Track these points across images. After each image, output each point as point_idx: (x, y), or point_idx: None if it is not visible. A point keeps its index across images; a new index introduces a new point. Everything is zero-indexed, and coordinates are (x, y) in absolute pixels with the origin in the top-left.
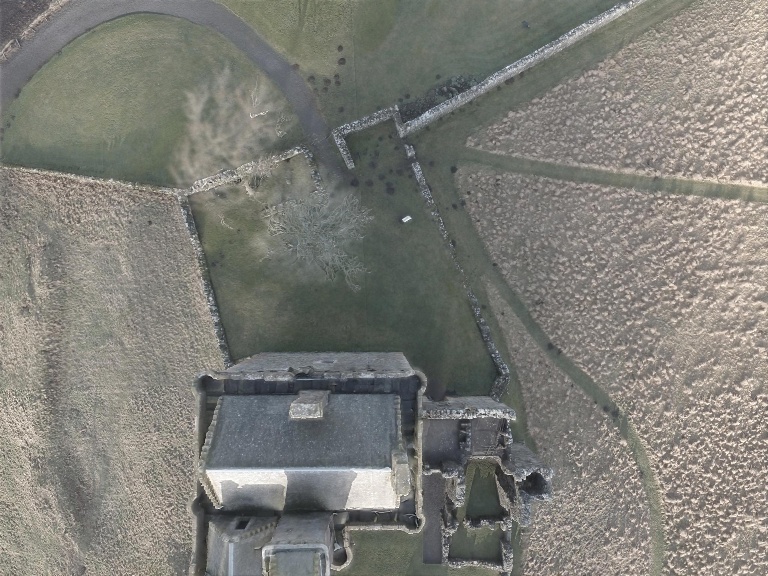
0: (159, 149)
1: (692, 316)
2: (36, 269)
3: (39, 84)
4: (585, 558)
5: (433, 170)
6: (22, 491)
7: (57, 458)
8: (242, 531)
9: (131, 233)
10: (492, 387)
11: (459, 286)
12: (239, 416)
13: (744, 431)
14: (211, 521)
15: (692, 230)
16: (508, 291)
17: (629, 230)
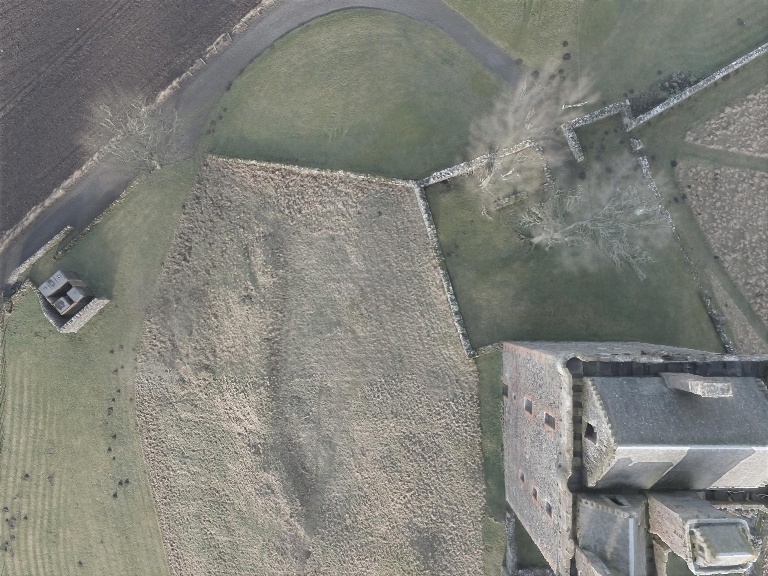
0: (386, 141)
1: None
2: (259, 258)
3: (253, 77)
4: None
5: (655, 164)
6: (235, 477)
7: (279, 444)
8: (630, 507)
9: (361, 223)
10: None
11: (689, 278)
12: (617, 396)
13: None
14: (584, 498)
15: None
16: (729, 283)
17: None
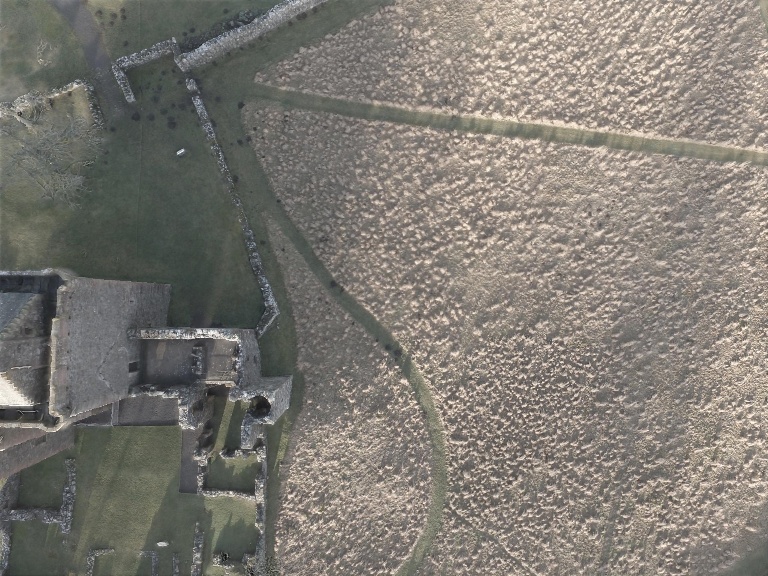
0: None
1: (486, 257)
2: None
3: None
4: (356, 494)
5: (219, 105)
6: None
7: None
8: None
9: None
10: (259, 320)
11: (234, 220)
12: None
13: (538, 374)
14: None
15: (489, 170)
16: (292, 228)
17: (422, 169)
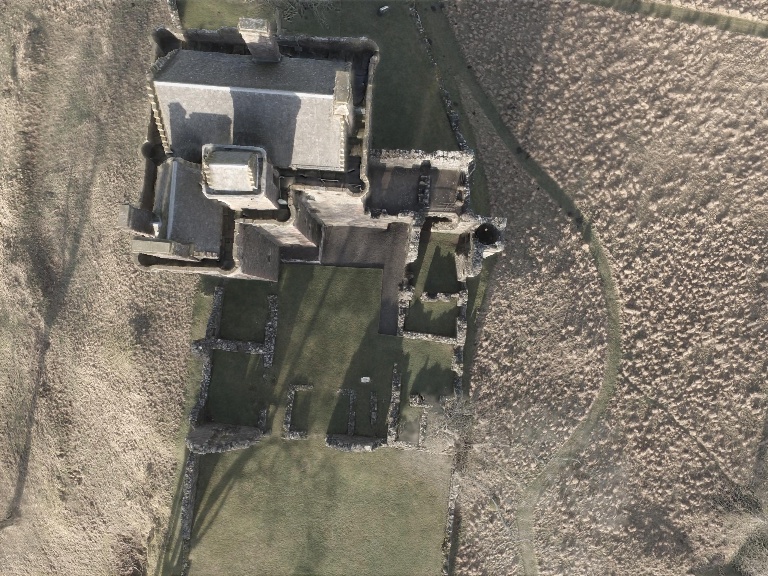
0: None
1: (662, 136)
2: (20, 52)
3: None
4: (540, 352)
5: None
6: None
7: (29, 237)
8: None
9: (114, 14)
10: None
11: (432, 78)
12: (192, 60)
13: (707, 253)
14: None
15: (667, 53)
16: (481, 94)
17: (605, 47)
